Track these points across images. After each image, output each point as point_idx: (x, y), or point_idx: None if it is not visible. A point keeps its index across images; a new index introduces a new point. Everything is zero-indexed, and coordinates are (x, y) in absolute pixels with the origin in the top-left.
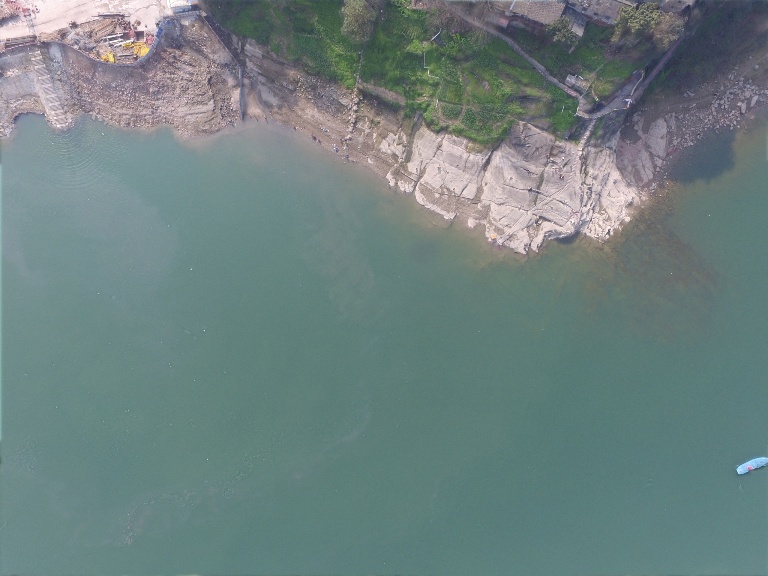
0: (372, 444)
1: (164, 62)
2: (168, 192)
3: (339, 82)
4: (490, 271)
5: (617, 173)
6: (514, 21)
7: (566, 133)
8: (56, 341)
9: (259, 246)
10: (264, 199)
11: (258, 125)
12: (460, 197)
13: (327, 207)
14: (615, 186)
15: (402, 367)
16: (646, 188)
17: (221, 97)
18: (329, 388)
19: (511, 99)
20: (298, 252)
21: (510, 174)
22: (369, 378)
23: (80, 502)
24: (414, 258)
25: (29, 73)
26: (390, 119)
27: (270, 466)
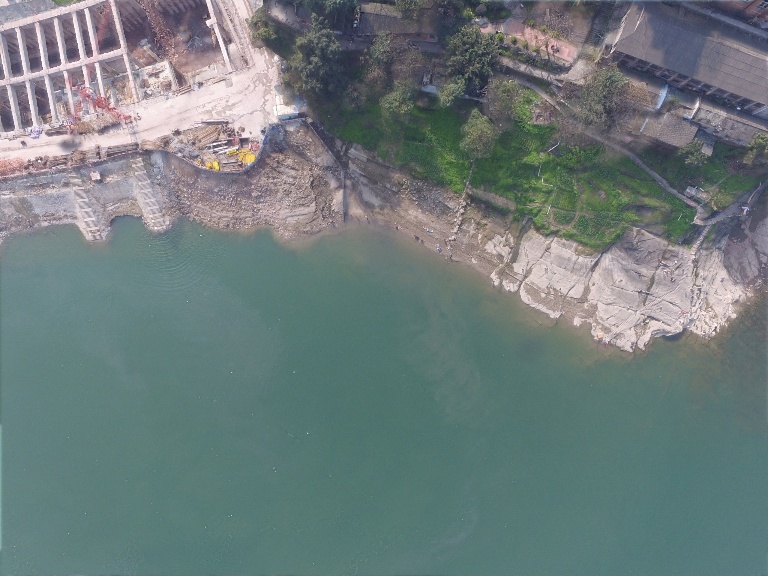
0: (480, 545)
1: (268, 167)
2: (269, 294)
3: (447, 186)
4: (596, 369)
5: (724, 272)
6: (639, 138)
7: (680, 238)
8: (156, 446)
9: (362, 347)
10: (366, 299)
11: (359, 225)
12: (566, 296)
13: (430, 307)
14: (722, 284)
15: (509, 467)
16: (752, 285)
17: (323, 199)
18: (436, 490)
19: (627, 207)
20: (402, 353)
21: (620, 276)
22: (476, 479)
23: None
24: (519, 357)
25: (128, 178)
26: (498, 222)
27: (377, 570)
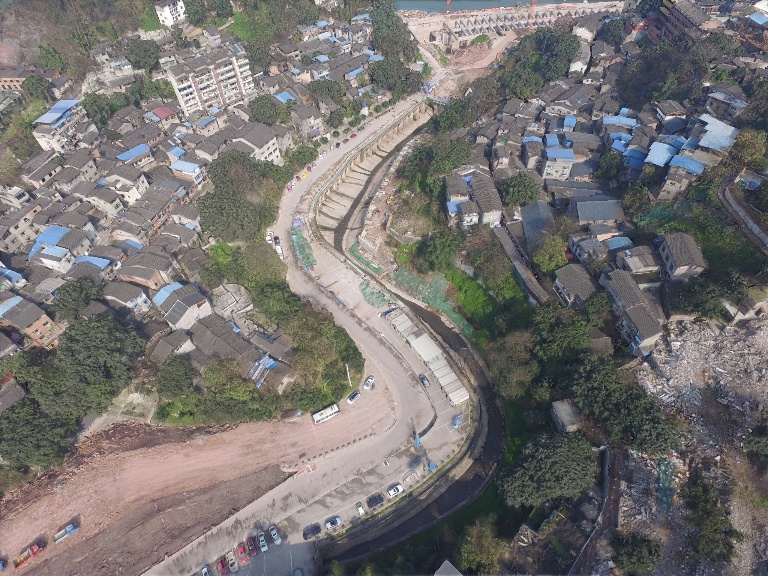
0: None
1: None
2: None
3: None
4: None
5: None
6: None
7: None
8: None
9: None
10: None
11: None
12: None
13: None
14: None
15: None
16: None
17: None
18: None
19: None
20: None
21: None
22: None
23: None
24: None
25: None
26: None
27: None
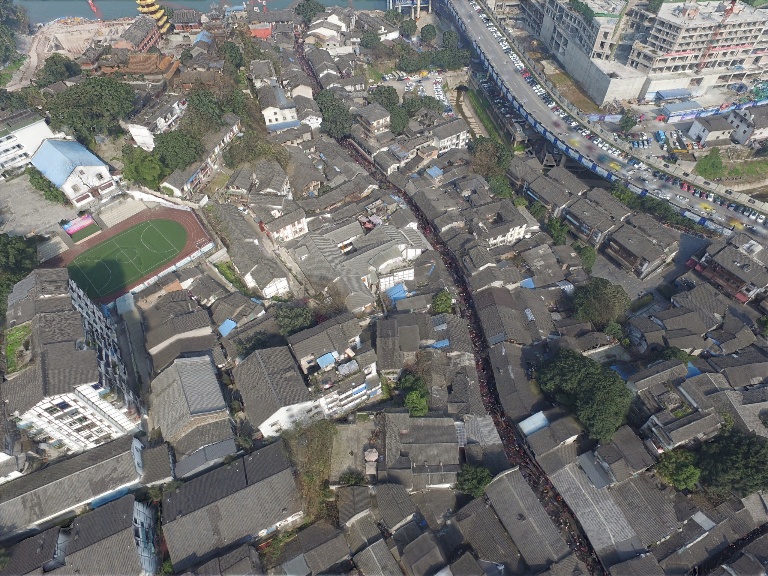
0: None
1: None
2: None
3: None
4: None
5: None
6: None
7: None
8: None
9: None
10: None
11: None
12: None
13: (32, 12)
14: None
15: None
16: None
17: None
18: None
19: None
20: (51, 5)
21: None
22: None
23: None
24: None
25: None
26: None
27: None
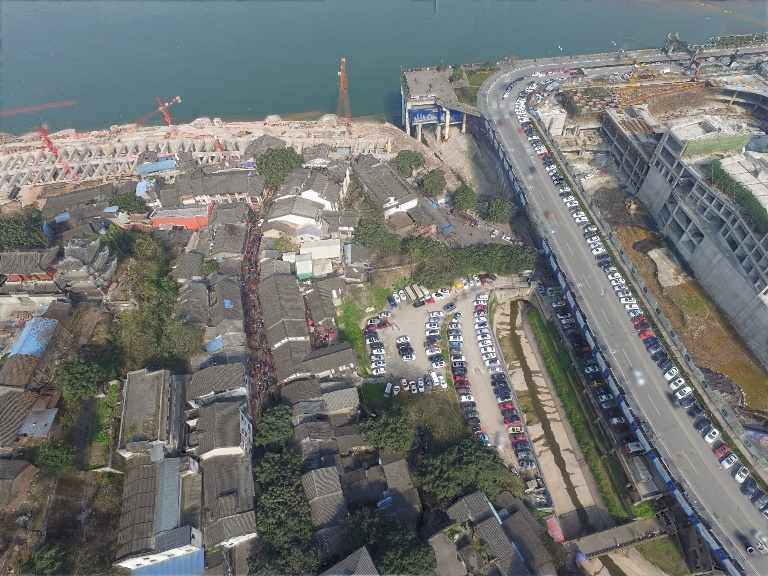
0: None
1: None
2: (2, 115)
3: None
4: None
5: None
6: None
7: None
8: (92, 77)
9: None
10: None
11: None
12: None
13: None
14: None
15: None
16: None
17: None
18: None
19: None
20: None
21: None
22: None
23: (115, 46)
24: None
25: None
26: None
27: None
